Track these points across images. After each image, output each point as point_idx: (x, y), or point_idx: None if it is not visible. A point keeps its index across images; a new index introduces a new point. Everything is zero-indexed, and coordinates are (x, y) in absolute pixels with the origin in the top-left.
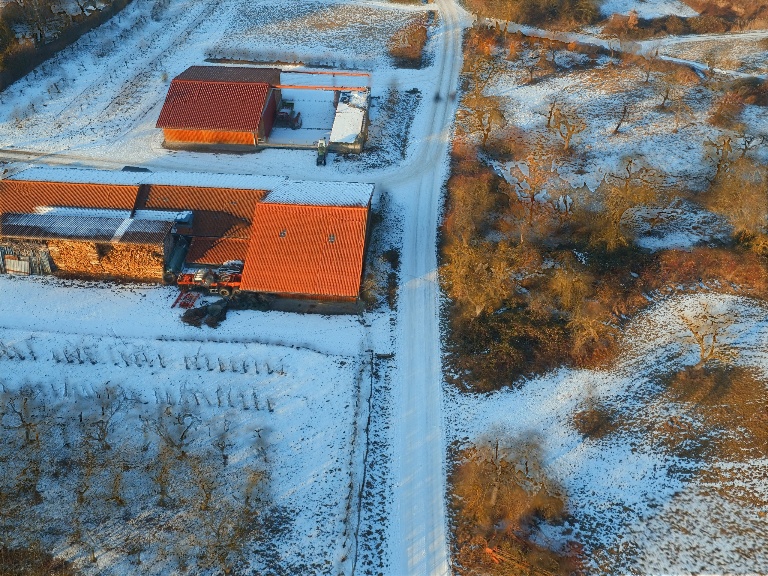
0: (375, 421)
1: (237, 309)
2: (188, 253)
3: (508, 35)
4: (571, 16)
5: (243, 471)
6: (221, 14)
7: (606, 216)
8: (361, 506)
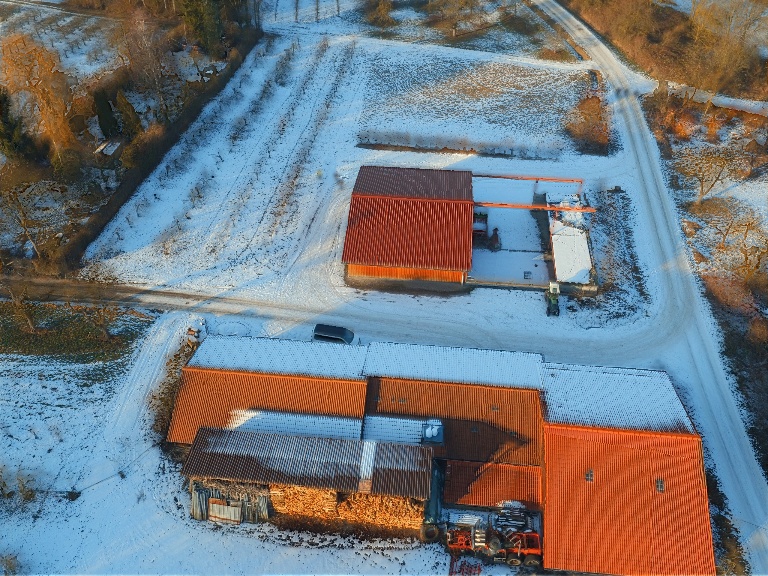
0: None
1: None
2: (446, 487)
3: (695, 106)
4: (764, 81)
5: None
6: (352, 75)
7: None
8: None
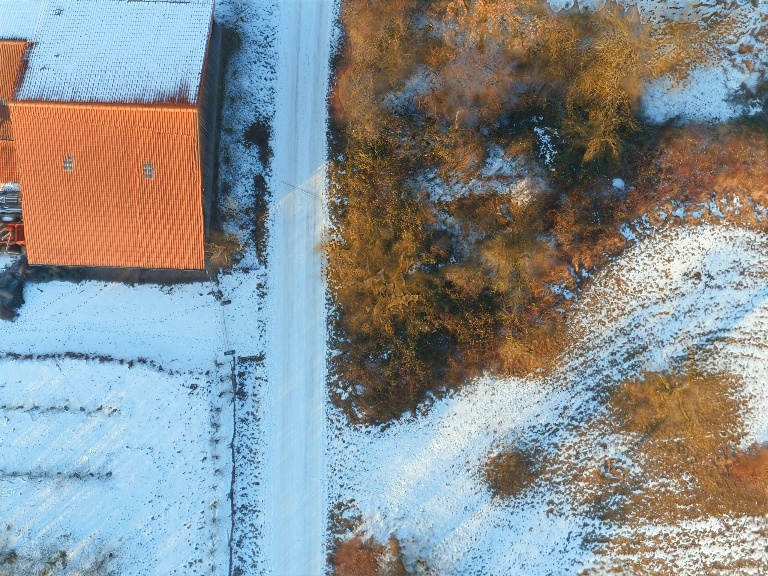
0: (242, 473)
1: (36, 281)
2: None
3: None
4: None
5: (87, 574)
6: None
7: (596, 90)
8: None
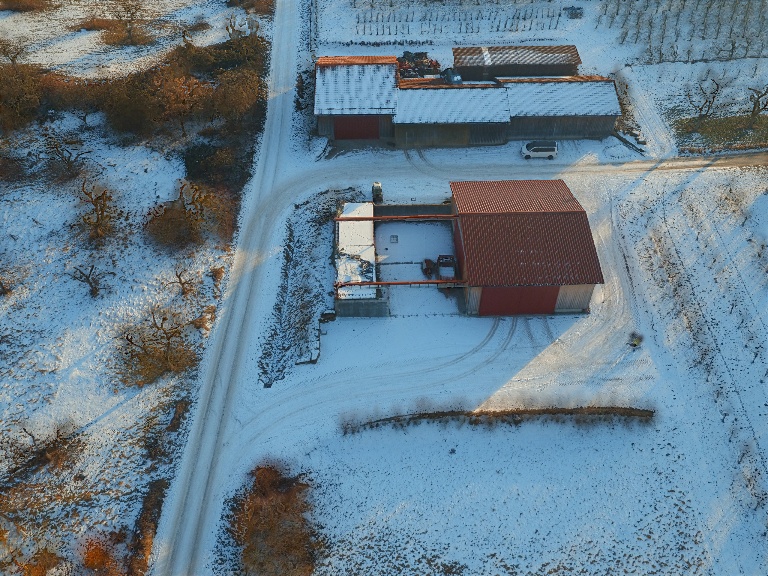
0: None
1: None
2: None
3: None
4: None
5: None
6: None
7: None
8: (311, 2)
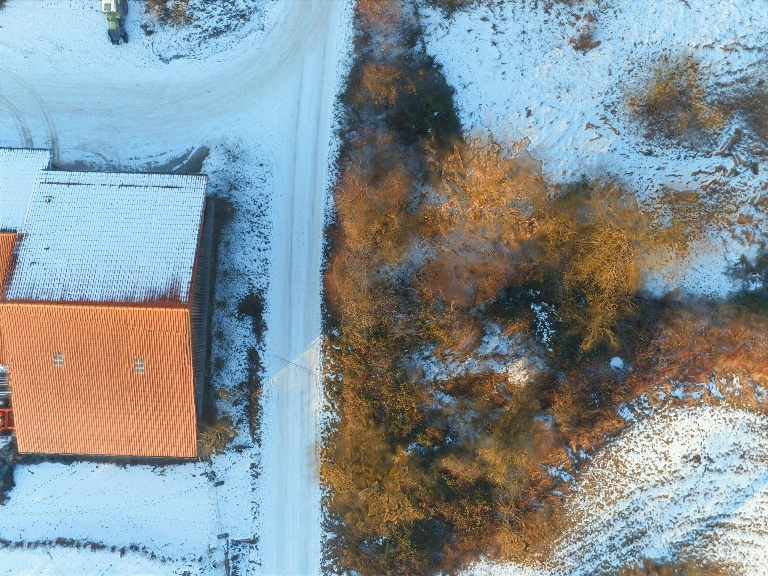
0: None
1: (27, 463)
2: None
3: None
4: None
5: None
6: None
7: (593, 282)
8: None
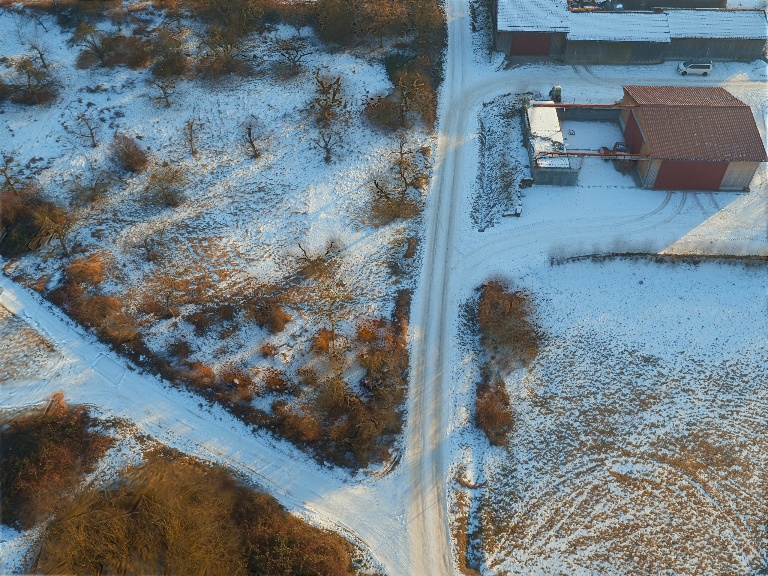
0: None
1: None
2: None
3: (311, 430)
4: None
5: None
6: None
7: None
8: None
